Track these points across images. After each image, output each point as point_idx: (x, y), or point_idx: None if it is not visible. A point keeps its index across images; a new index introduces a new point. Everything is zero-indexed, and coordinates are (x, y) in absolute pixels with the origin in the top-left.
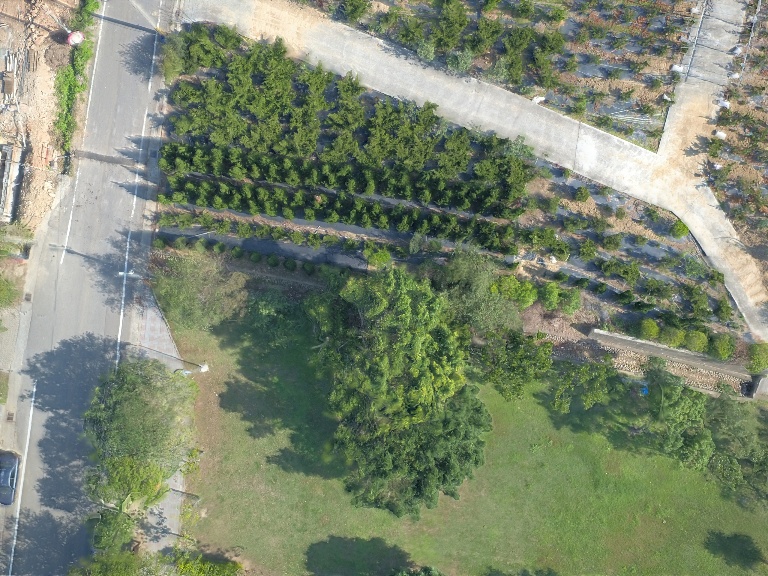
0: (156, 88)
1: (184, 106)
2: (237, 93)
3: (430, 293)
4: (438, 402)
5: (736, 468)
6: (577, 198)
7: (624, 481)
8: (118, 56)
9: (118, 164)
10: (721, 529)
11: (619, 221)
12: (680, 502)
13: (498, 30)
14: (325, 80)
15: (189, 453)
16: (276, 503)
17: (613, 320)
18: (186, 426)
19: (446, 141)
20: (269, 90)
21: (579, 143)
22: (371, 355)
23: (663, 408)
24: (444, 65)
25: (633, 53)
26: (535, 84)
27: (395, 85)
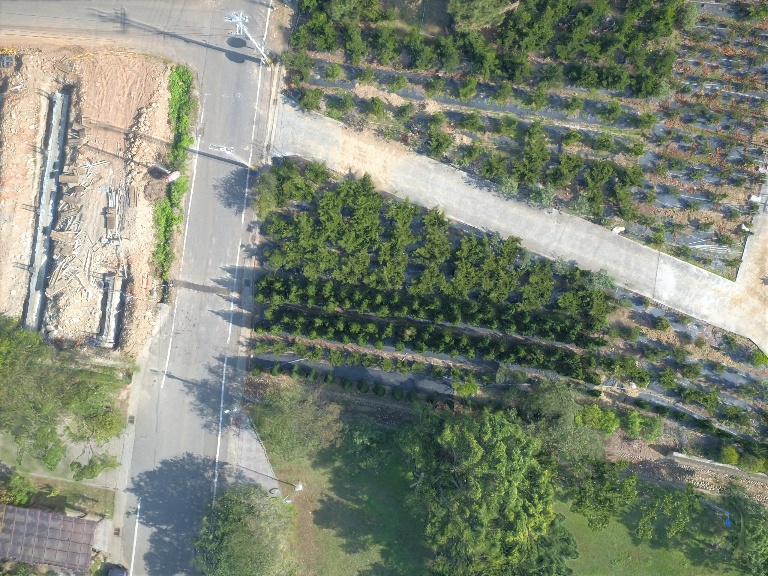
0: (249, 220)
1: (277, 239)
2: (328, 228)
3: (521, 432)
4: (531, 541)
5: None
6: (658, 328)
7: None
8: (213, 190)
9: (214, 293)
10: None
11: (698, 348)
12: None
13: (580, 164)
14: (412, 213)
15: (288, 574)
16: None
17: (692, 444)
18: (287, 552)
19: (531, 275)
20: (359, 225)
21: (659, 272)
22: (470, 502)
23: (745, 540)
24: (526, 197)
25: (712, 183)
26: (615, 215)
27: (479, 217)
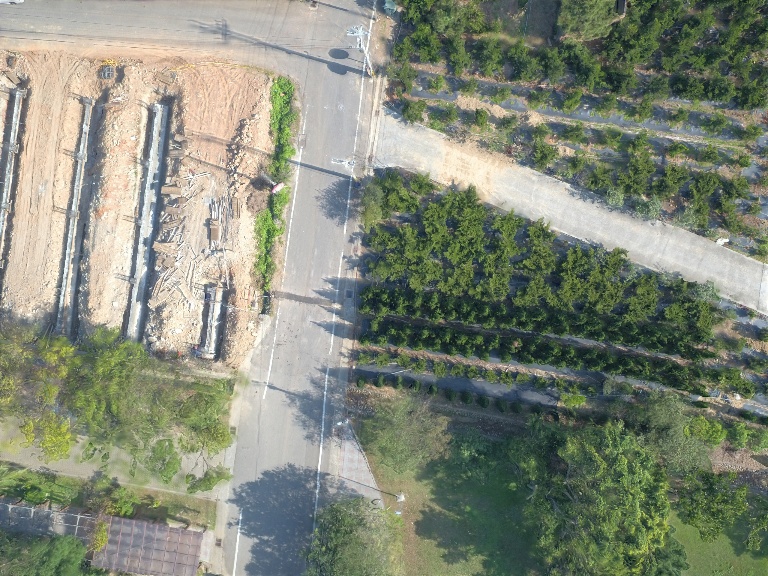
0: (351, 231)
1: (380, 250)
2: (434, 240)
3: (635, 444)
4: (650, 553)
5: None
6: (763, 340)
7: None
8: (315, 201)
9: (316, 304)
10: None
11: None
12: None
13: (686, 176)
14: (516, 225)
15: None
16: None
17: None
18: (397, 563)
19: (637, 287)
20: (464, 236)
21: (763, 284)
22: (593, 515)
23: None
24: (630, 208)
25: None
26: (719, 226)
27: (583, 228)
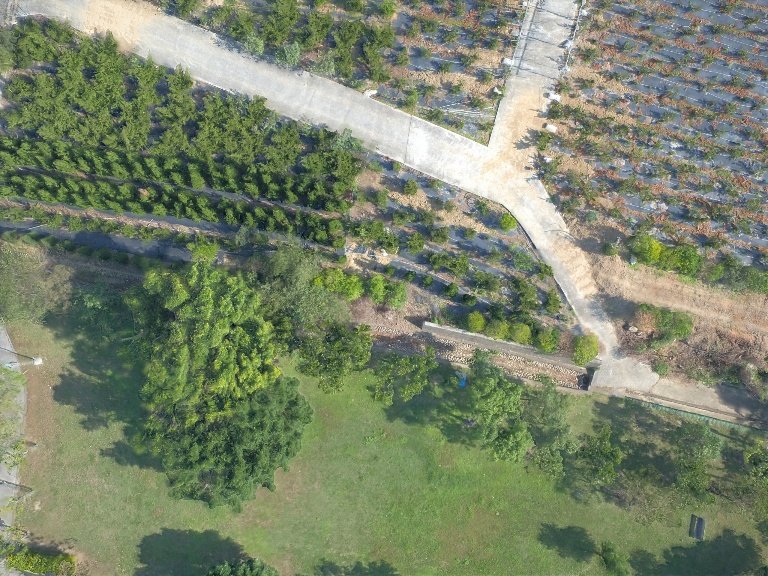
0: None
1: (16, 99)
2: (66, 86)
3: (243, 285)
4: (244, 394)
5: (557, 460)
6: (405, 191)
7: (457, 473)
8: None
9: None
10: (554, 521)
11: (450, 214)
12: (514, 494)
13: (328, 23)
14: (156, 73)
15: (14, 445)
16: (109, 495)
17: (443, 313)
18: (6, 418)
19: (273, 134)
20: (99, 83)
21: (410, 136)
22: (169, 347)
23: (478, 400)
24: None
25: (465, 46)
26: (367, 77)
27: (227, 78)
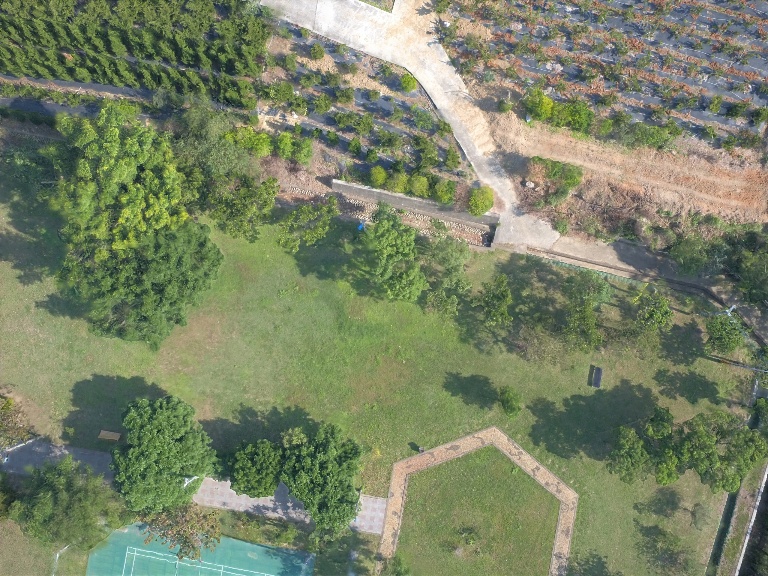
0: None
1: None
2: None
3: (153, 134)
4: (150, 228)
5: (451, 301)
6: (312, 55)
7: (366, 324)
8: None
9: None
10: (458, 369)
11: (356, 78)
12: (419, 344)
13: None
14: None
15: None
16: (44, 344)
17: (350, 171)
18: None
19: (188, 2)
20: None
21: (318, 5)
22: (78, 180)
23: None
24: None
25: None
26: None
27: None
